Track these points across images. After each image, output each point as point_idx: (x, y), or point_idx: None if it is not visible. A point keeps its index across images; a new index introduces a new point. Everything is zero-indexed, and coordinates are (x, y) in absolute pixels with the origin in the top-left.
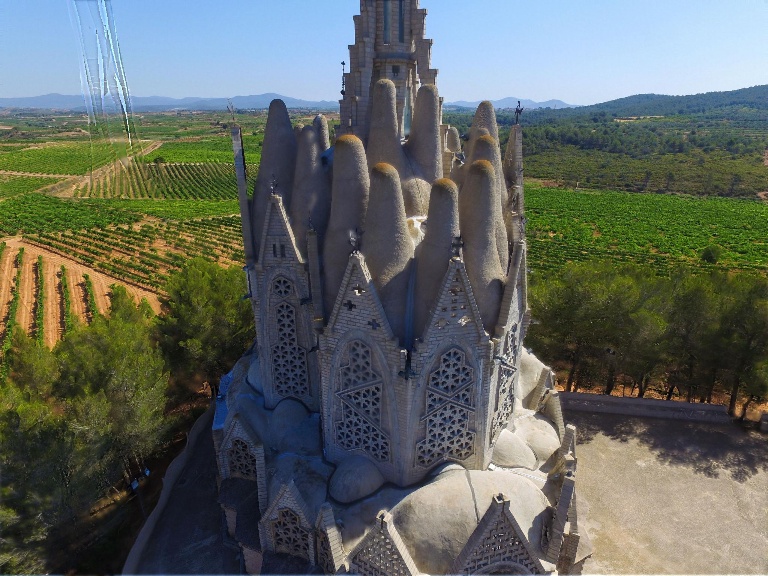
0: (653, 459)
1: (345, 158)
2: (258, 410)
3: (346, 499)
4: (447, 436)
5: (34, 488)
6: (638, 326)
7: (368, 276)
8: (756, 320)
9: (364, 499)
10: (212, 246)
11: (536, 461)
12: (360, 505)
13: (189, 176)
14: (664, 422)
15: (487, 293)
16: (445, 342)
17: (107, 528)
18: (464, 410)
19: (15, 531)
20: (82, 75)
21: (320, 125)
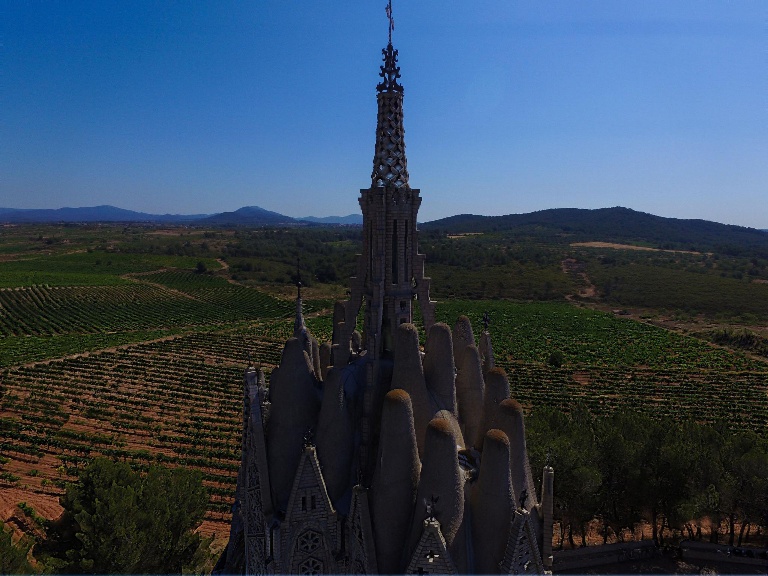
0: None
1: (399, 415)
2: None
3: None
4: None
5: None
6: (581, 481)
7: (443, 541)
8: (659, 459)
9: None
10: (56, 401)
11: None
12: None
13: (5, 305)
14: (614, 568)
15: None
16: None
17: None
18: None
19: None
20: None
21: (306, 338)
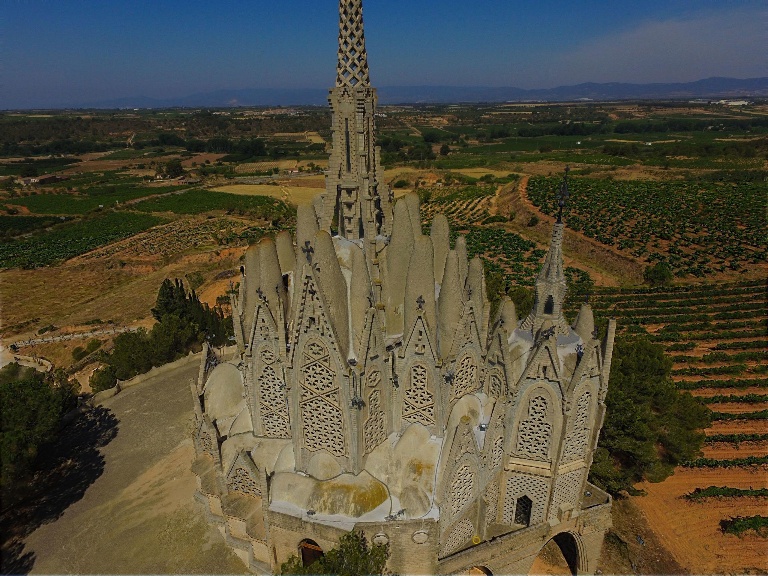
0: None
1: None
2: None
3: None
4: None
5: None
6: None
7: None
8: None
9: None
10: None
11: None
12: None
13: None
14: None
15: None
16: None
17: None
18: None
19: None
20: None
21: None
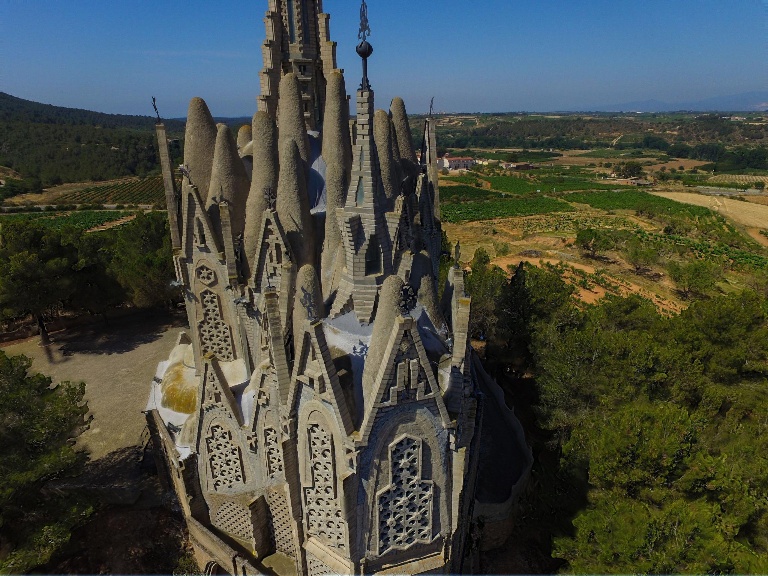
0: None
1: None
2: None
3: None
4: None
5: None
6: None
7: None
8: None
9: None
10: None
11: None
12: None
13: None
14: None
15: None
16: None
17: (491, 345)
18: None
19: None
20: None
21: None
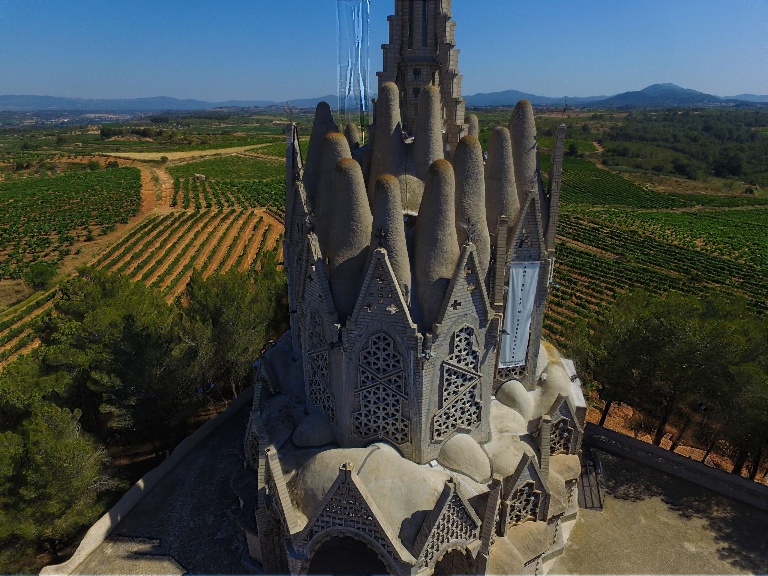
0: (712, 549)
1: (327, 153)
2: (285, 359)
3: (299, 443)
4: (382, 416)
5: (133, 369)
6: (739, 383)
7: (318, 255)
8: None
9: (310, 448)
10: None
11: (490, 476)
12: (304, 451)
13: None
14: (767, 517)
15: (432, 289)
16: (374, 325)
17: (180, 415)
18: (397, 396)
19: (121, 394)
20: (336, 79)
21: None
